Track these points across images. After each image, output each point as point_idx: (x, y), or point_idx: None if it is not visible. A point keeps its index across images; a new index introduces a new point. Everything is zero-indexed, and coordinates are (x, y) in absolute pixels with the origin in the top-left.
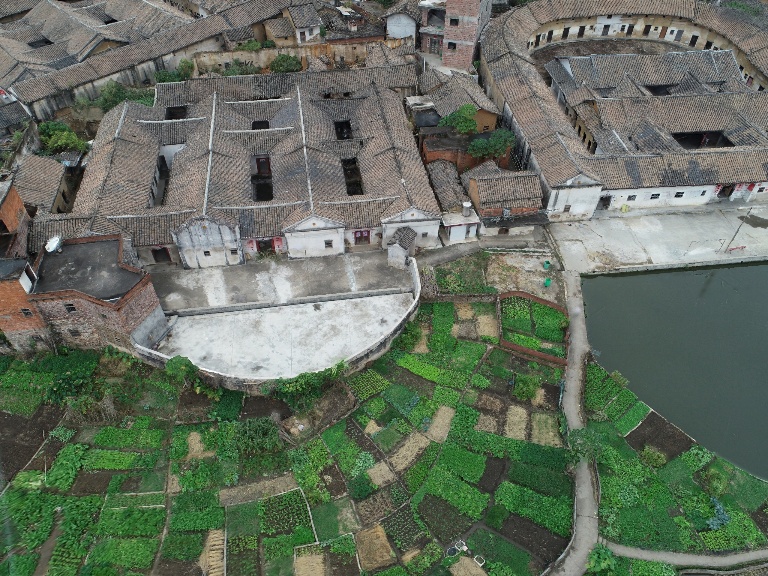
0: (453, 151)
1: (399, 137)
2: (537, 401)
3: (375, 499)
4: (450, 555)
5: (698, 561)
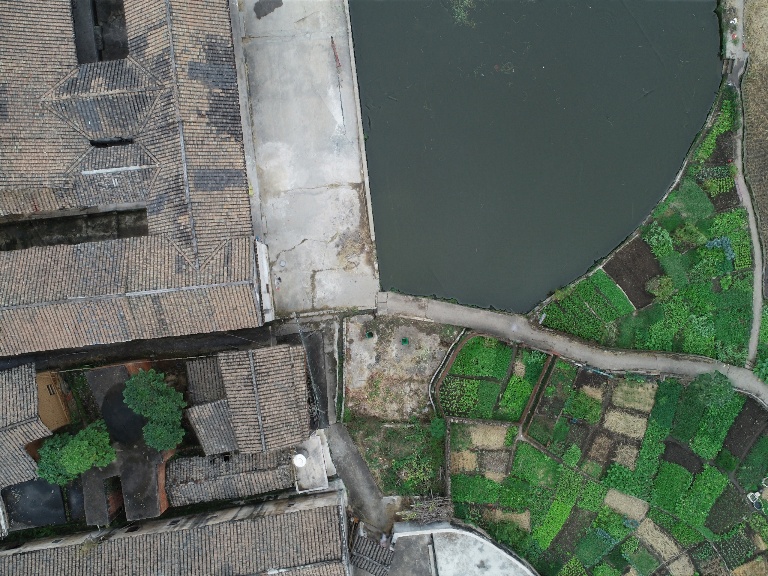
0: (157, 471)
1: (138, 573)
2: (600, 397)
3: (708, 575)
4: (761, 507)
5: (759, 279)
